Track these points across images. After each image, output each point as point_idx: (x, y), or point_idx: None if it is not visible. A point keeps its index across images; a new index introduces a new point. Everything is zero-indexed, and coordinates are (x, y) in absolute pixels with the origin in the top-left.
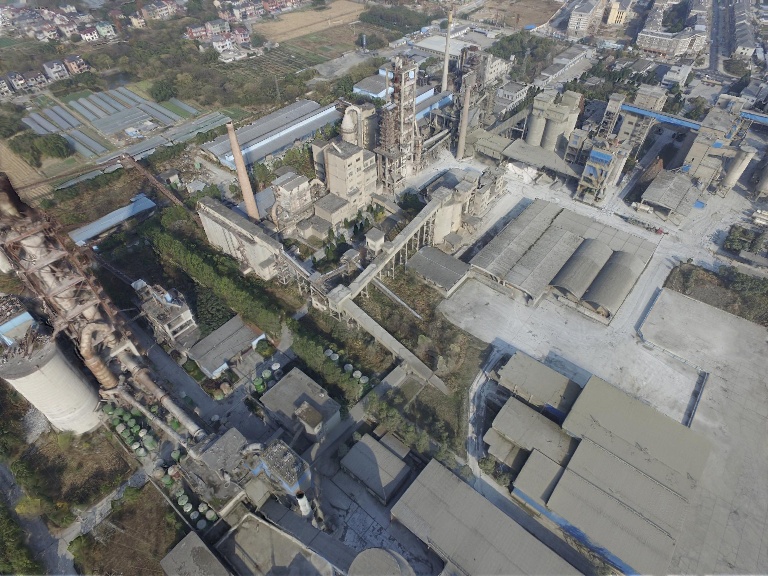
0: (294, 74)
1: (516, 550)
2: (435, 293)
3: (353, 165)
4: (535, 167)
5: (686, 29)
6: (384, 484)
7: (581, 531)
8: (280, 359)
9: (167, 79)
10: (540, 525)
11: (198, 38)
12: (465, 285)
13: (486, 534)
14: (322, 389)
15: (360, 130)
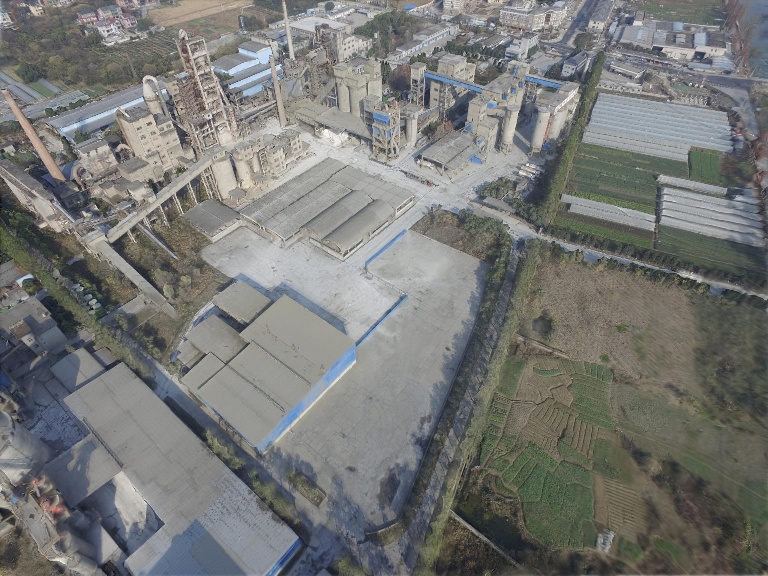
0: (167, 55)
1: (154, 424)
2: (203, 239)
3: (144, 129)
4: (346, 132)
5: (542, 5)
6: (77, 384)
7: (215, 410)
8: (42, 295)
9: (41, 62)
10: (203, 412)
11: (89, 24)
12: (235, 232)
13: (135, 414)
14: (47, 312)
15: (162, 98)
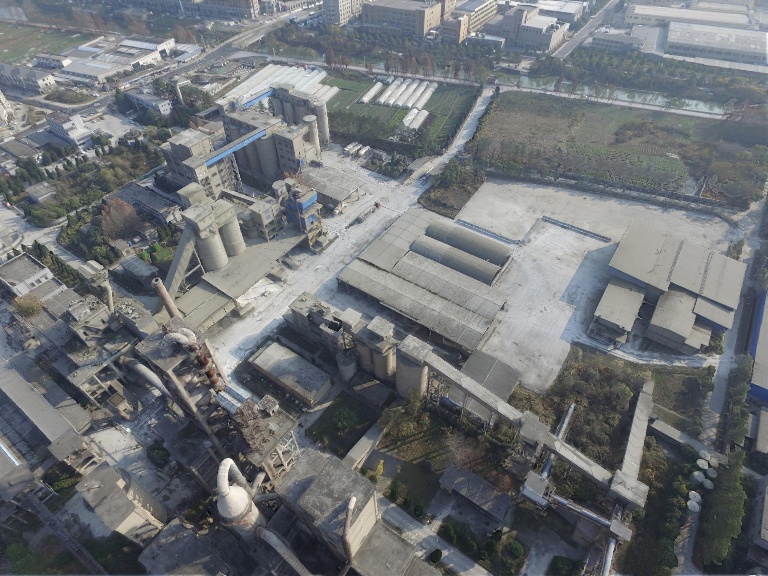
0: None
1: None
2: (519, 393)
3: None
4: None
5: None
6: None
7: None
8: None
9: None
10: None
11: None
12: None
13: None
14: None
15: None
